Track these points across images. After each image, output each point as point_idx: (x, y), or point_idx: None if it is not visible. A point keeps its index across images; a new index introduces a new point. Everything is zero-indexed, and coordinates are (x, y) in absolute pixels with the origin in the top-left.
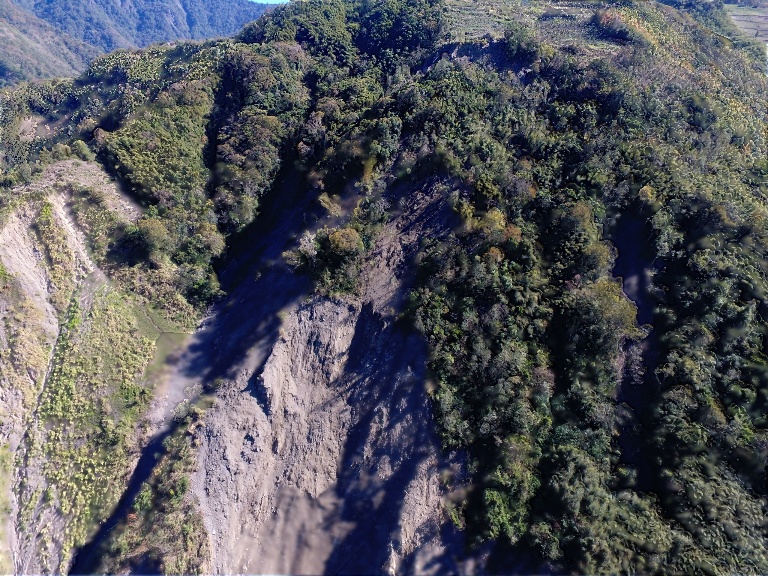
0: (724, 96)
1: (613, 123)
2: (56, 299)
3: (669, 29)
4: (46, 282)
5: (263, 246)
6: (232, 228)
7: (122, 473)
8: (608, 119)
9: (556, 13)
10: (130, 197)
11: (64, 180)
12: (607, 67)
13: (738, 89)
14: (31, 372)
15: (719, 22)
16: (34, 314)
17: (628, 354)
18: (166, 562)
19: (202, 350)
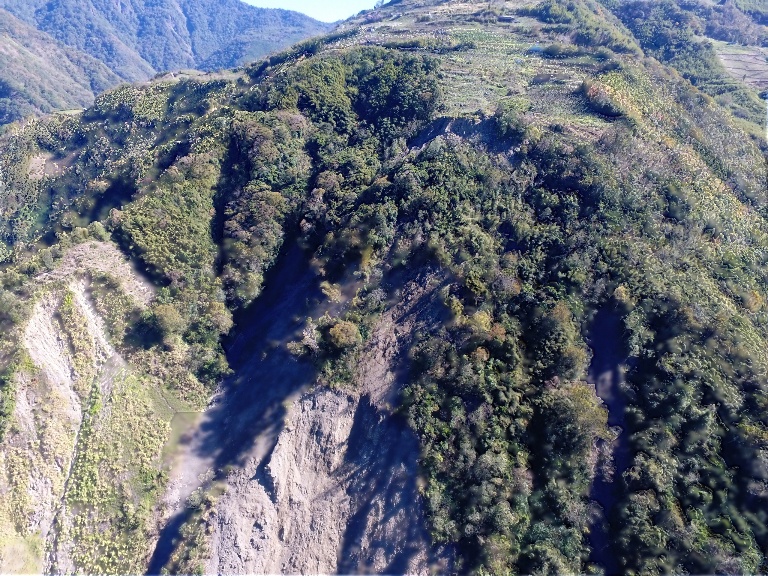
0: (699, 184)
1: (593, 217)
2: (79, 387)
3: (653, 97)
4: (69, 370)
5: (268, 323)
6: (239, 302)
7: (142, 556)
8: (589, 212)
9: (546, 78)
10: (144, 276)
11: (83, 266)
12: (589, 156)
13: (718, 157)
14: (58, 460)
15: (708, 64)
16: (60, 404)
17: (601, 450)
18: None
19: (213, 429)
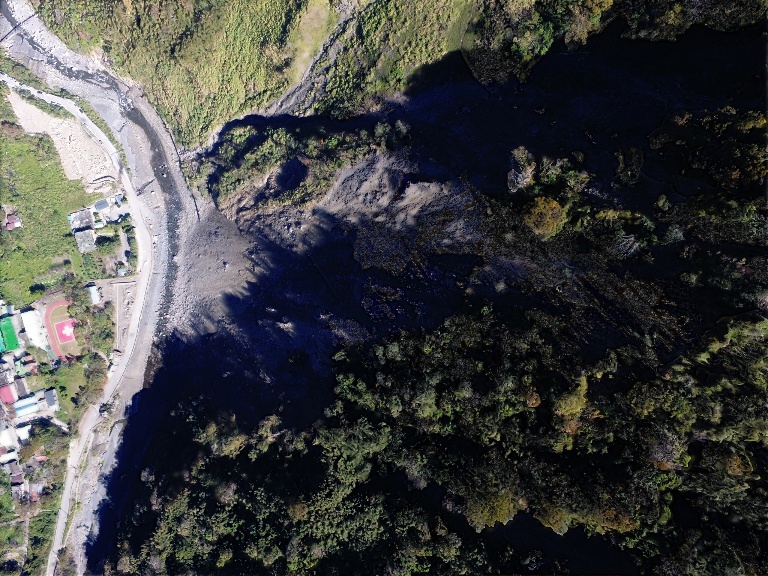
0: None
1: None
2: None
3: None
4: None
5: (601, 86)
6: None
7: (351, 109)
8: None
9: None
10: None
11: None
12: None
13: None
14: None
15: None
16: None
17: None
18: (307, 179)
19: (458, 99)
